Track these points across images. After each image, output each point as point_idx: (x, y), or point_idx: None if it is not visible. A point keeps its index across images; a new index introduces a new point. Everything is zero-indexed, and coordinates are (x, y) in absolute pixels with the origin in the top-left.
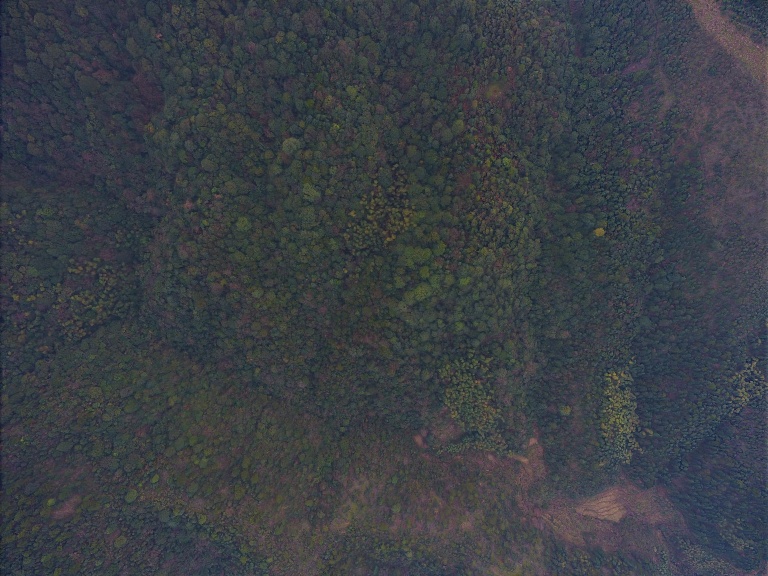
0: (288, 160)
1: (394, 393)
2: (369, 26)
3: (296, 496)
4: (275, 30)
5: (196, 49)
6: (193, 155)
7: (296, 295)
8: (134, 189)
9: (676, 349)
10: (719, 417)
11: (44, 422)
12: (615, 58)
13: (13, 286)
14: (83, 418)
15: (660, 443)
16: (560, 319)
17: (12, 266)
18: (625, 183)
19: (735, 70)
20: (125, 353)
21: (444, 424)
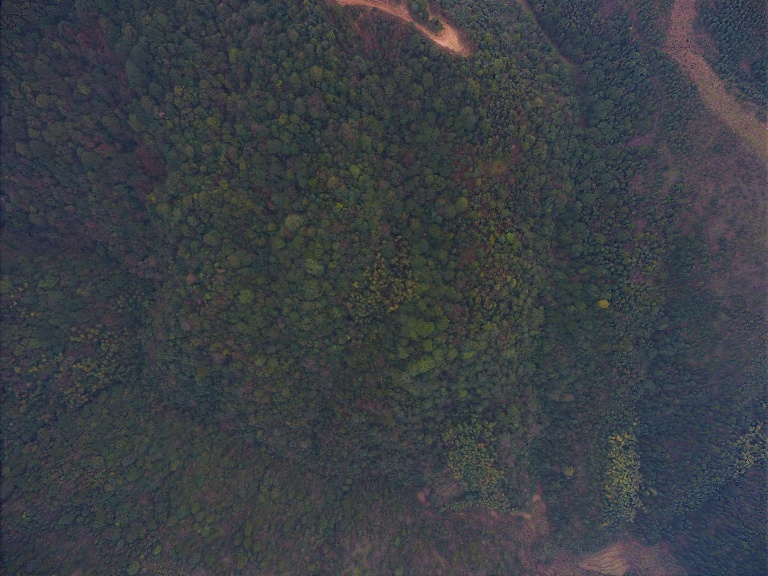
0: (291, 235)
1: (397, 455)
2: (372, 106)
3: (298, 561)
4: (278, 112)
5: (199, 127)
6: (196, 230)
7: (299, 359)
8: (136, 254)
9: (680, 412)
10: (723, 478)
11: (46, 496)
12: (619, 130)
13: (15, 359)
14: (85, 490)
15: (664, 502)
16: (564, 383)
17: (14, 339)
18: (629, 257)
19: (740, 148)
20: (127, 417)
21: (447, 483)
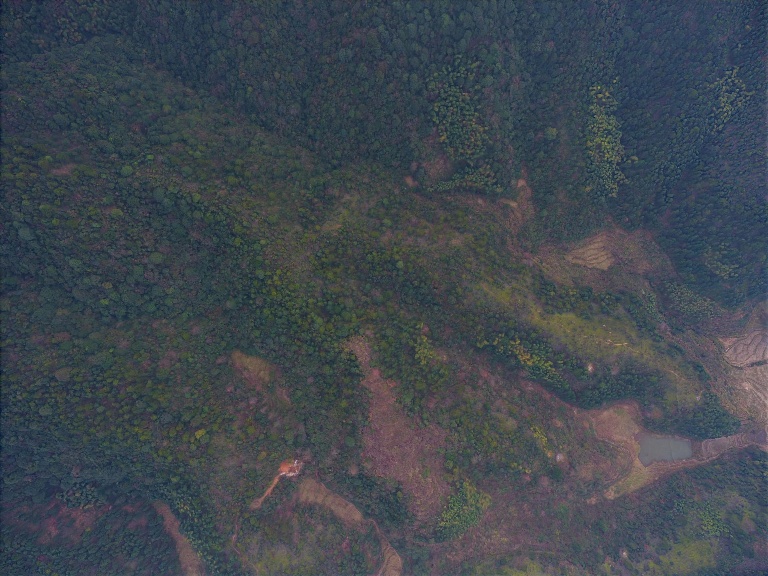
0: None
1: (384, 110)
2: None
3: (289, 201)
4: None
5: None
6: None
7: (286, 6)
8: None
9: (659, 60)
10: (702, 135)
11: (41, 89)
12: None
13: None
14: (79, 93)
15: (645, 171)
16: (544, 25)
17: None
18: None
19: None
20: (120, 63)
21: (434, 155)
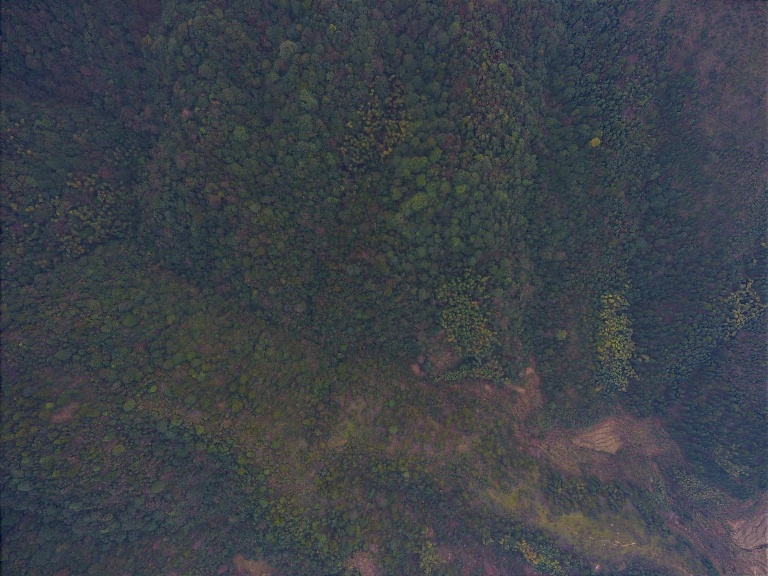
0: (285, 66)
1: (391, 315)
2: None
3: (293, 414)
4: None
5: None
6: (191, 61)
7: (293, 215)
8: (132, 107)
9: (672, 271)
10: (715, 341)
11: (42, 328)
12: None
13: (12, 195)
14: (81, 327)
15: (656, 369)
16: (556, 238)
17: (11, 174)
18: (620, 91)
19: None
20: (123, 272)
21: (441, 350)
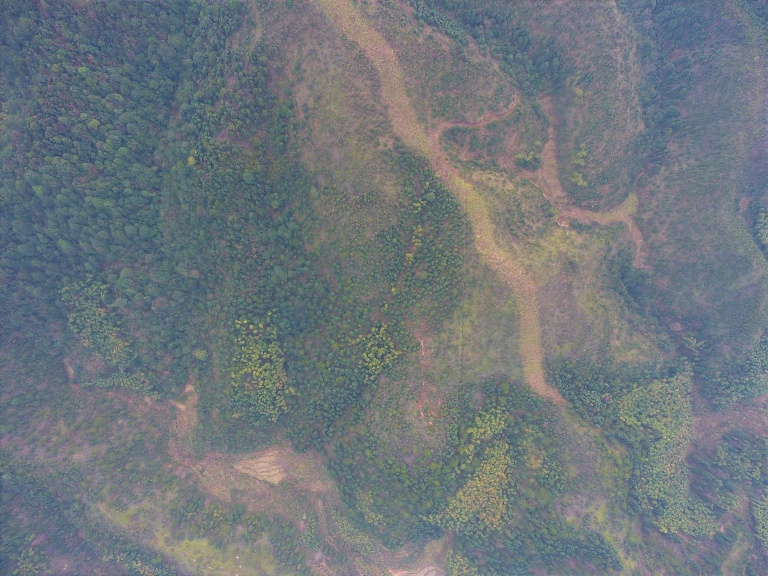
0: None
1: (20, 311)
2: None
3: None
4: None
5: None
6: None
7: None
8: None
9: (308, 304)
10: (354, 382)
11: None
12: None
13: None
14: None
15: (303, 403)
16: (185, 255)
17: None
18: (211, 112)
19: (309, 5)
20: None
21: (87, 354)
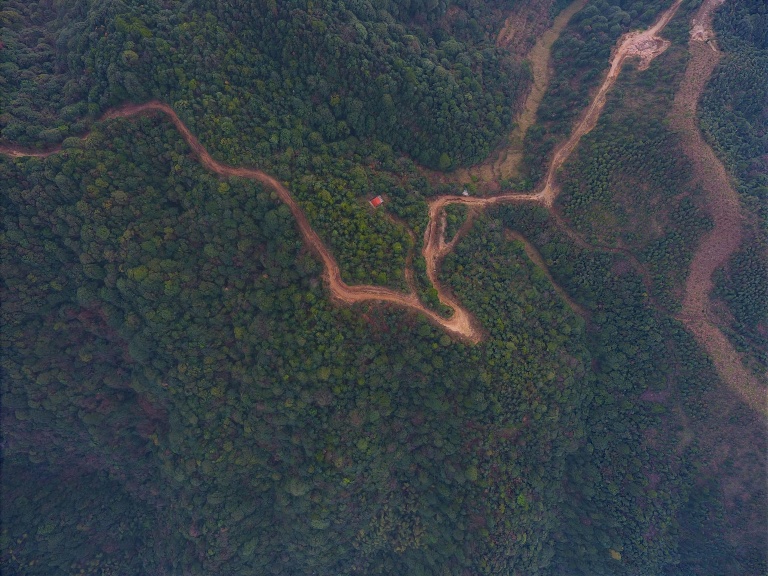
0: None
1: None
2: (381, 383)
3: None
4: (284, 396)
5: (203, 397)
6: (199, 488)
7: None
8: (138, 479)
9: None
10: None
11: None
12: (632, 382)
13: None
14: None
15: None
16: None
17: None
18: (642, 514)
19: (757, 422)
20: None
21: None
